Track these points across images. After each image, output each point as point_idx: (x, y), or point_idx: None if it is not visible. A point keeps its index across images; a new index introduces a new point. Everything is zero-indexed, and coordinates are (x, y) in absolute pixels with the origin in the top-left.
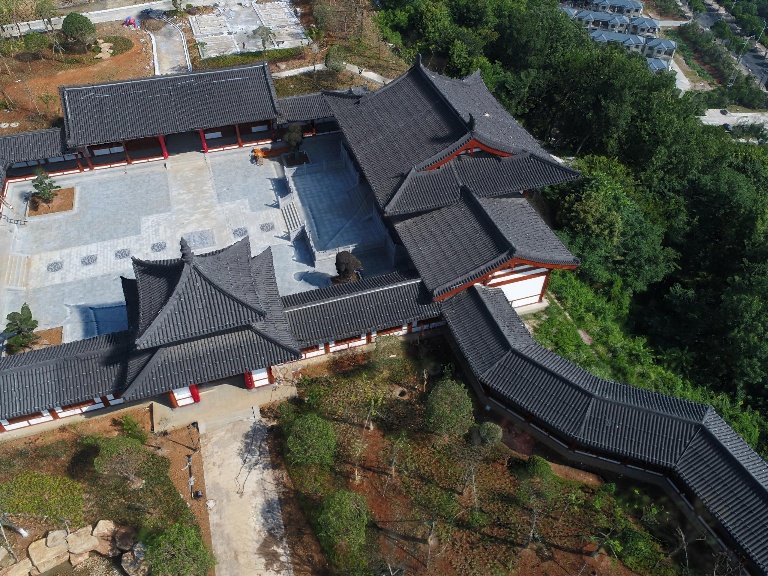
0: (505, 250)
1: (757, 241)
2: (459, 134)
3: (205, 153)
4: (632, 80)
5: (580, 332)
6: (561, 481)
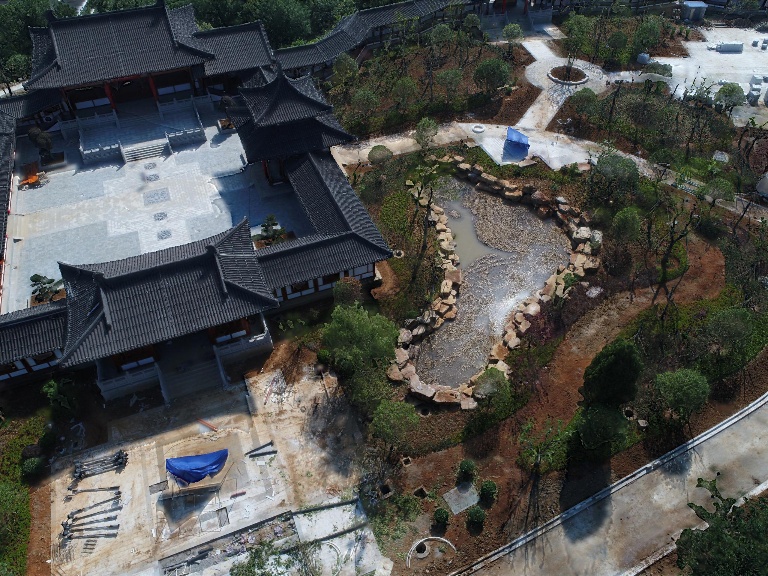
0: (256, 28)
1: (230, 2)
2: (158, 14)
3: (10, 213)
4: (40, 7)
5: None
6: None
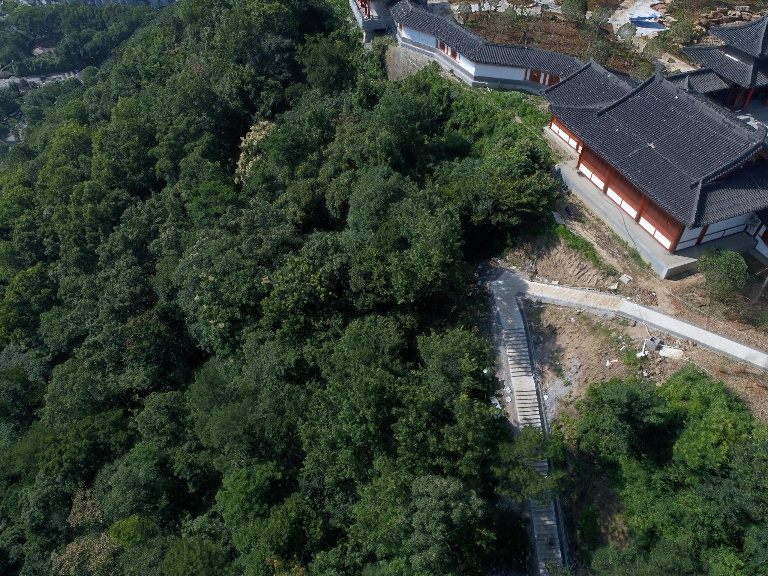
0: None
1: None
2: None
3: None
4: None
5: (521, 122)
6: None
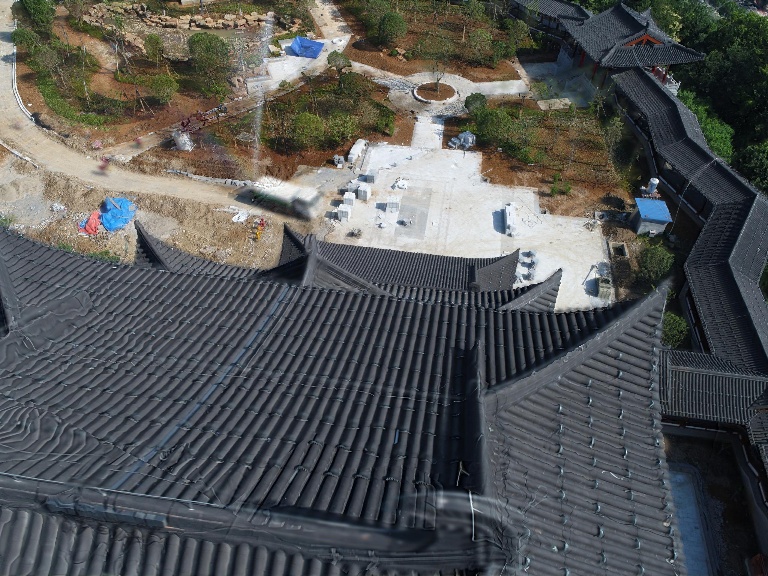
0: None
1: None
2: None
3: None
4: None
5: None
6: (452, 6)
